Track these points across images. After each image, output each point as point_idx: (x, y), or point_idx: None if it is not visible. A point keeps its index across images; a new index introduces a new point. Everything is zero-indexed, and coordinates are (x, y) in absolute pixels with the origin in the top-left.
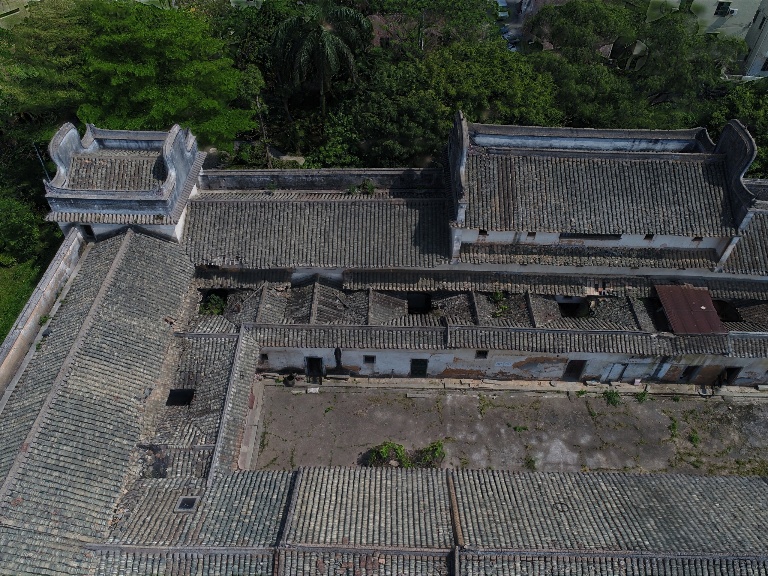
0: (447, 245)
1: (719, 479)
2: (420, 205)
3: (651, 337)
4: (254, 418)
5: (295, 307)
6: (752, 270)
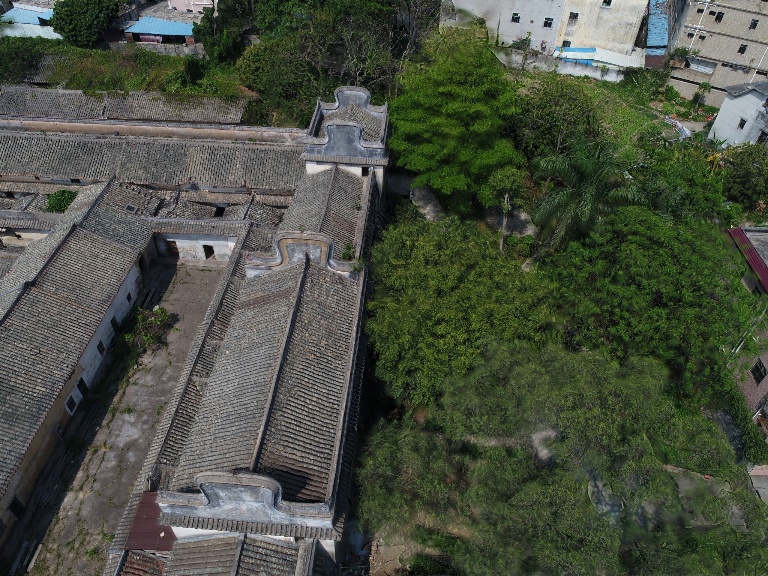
0: None
1: (4, 475)
2: None
3: None
4: (223, 264)
5: (268, 249)
6: None
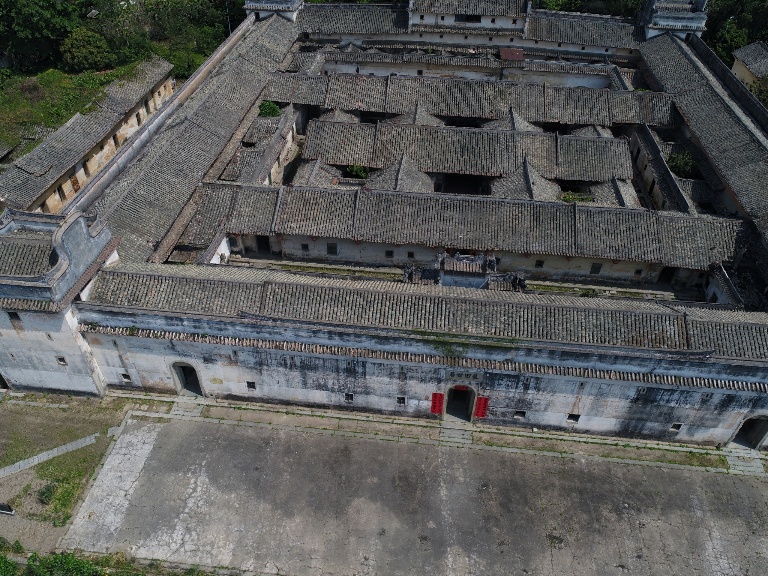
0: (407, 25)
1: None
2: (397, 11)
3: (491, 60)
4: None
5: None
6: (540, 38)
